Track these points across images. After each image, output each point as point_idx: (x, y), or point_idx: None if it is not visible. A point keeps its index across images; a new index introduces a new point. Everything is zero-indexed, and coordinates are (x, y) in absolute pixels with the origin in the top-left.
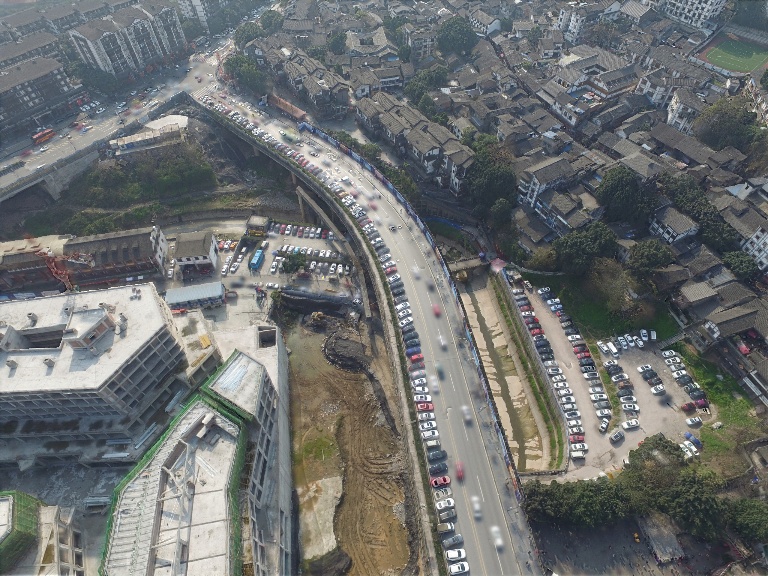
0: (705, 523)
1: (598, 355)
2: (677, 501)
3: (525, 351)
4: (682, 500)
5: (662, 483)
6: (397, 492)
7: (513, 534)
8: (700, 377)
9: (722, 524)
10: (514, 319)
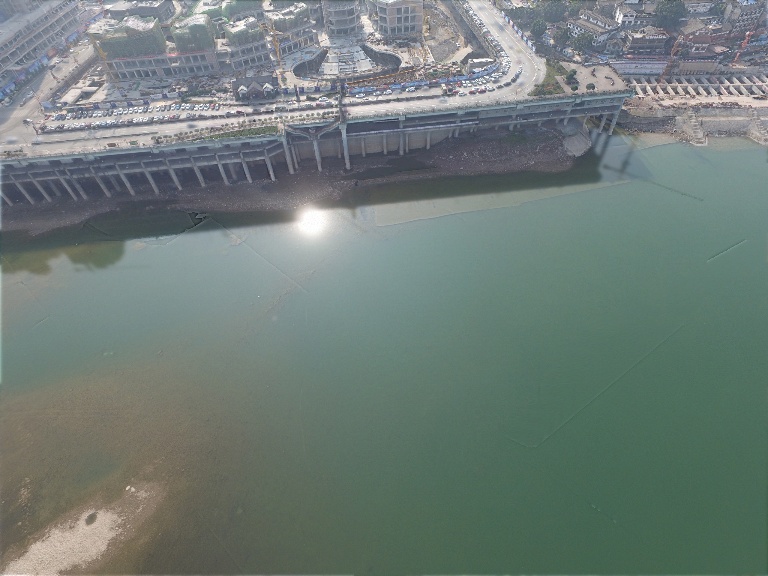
0: (557, 8)
1: (530, 0)
2: (549, 6)
3: (500, 7)
4: (550, 3)
5: (545, 5)
6: (450, 28)
7: (491, 10)
8: (570, 0)
9: (564, 10)
10: (496, 0)
